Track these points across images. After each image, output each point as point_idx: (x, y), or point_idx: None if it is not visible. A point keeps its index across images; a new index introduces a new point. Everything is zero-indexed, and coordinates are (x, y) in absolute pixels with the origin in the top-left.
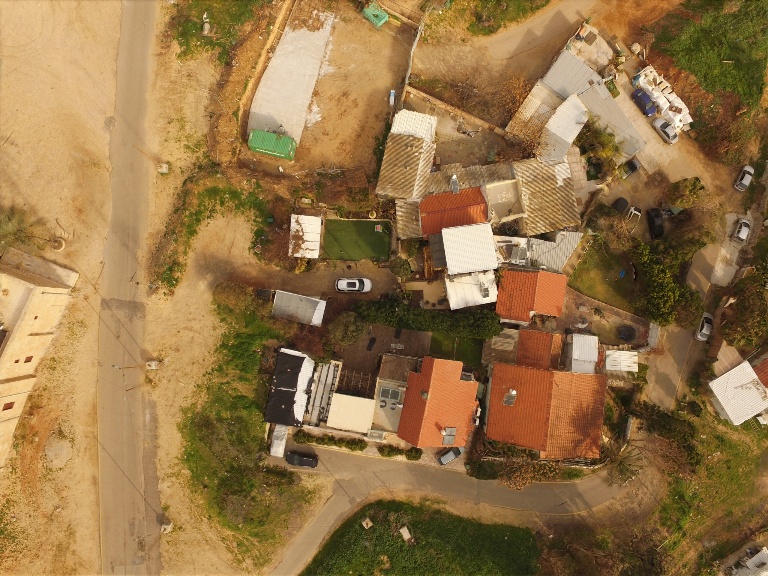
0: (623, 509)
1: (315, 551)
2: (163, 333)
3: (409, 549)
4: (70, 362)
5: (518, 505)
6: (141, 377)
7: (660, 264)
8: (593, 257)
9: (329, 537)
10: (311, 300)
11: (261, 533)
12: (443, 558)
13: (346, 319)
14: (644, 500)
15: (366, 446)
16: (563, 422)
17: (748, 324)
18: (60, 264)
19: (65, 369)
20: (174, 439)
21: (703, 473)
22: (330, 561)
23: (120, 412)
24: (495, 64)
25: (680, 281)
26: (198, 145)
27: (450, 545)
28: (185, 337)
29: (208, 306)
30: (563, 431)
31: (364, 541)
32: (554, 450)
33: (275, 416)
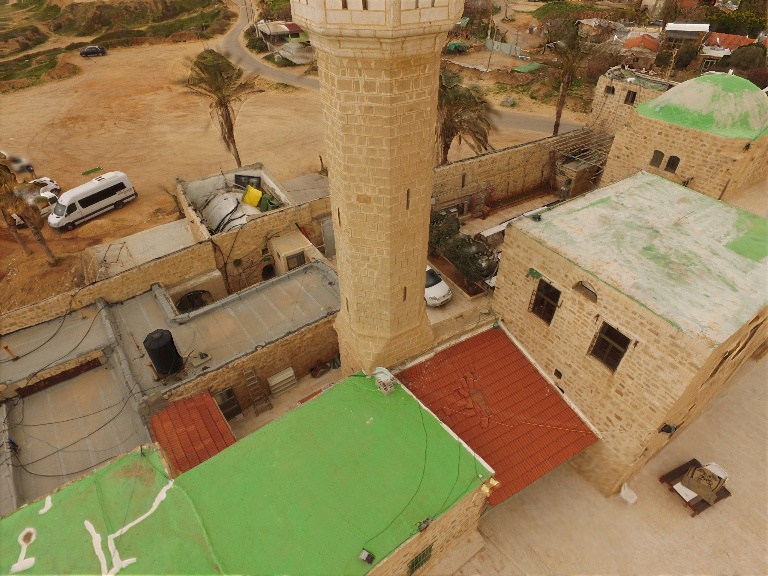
0: None
1: None
2: None
3: None
4: None
5: None
6: None
7: None
8: None
9: None
10: None
11: None
12: None
13: None
14: None
15: None
16: None
17: None
18: None
19: None
20: None
21: None
22: None
23: None
24: (527, 45)
25: None
26: (501, 88)
27: None
28: None
29: None
30: None
31: None
32: None
33: None
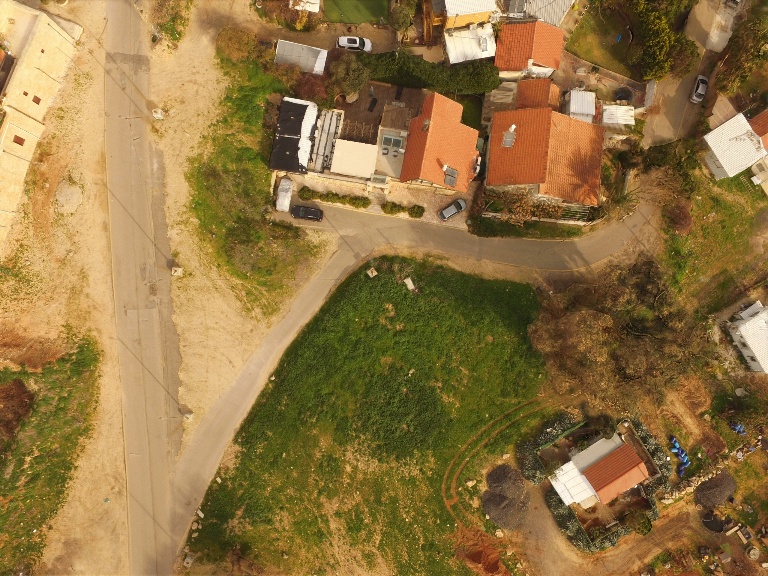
0: (621, 265)
1: (322, 302)
2: (168, 86)
3: (413, 297)
4: (77, 112)
5: (519, 262)
6: (147, 127)
7: (656, 11)
8: (590, 22)
9: (335, 289)
10: (313, 49)
11: (269, 282)
12: (446, 307)
13: (347, 57)
14: (641, 257)
15: (369, 203)
16: (561, 163)
17: (742, 59)
18: (64, 18)
19: (73, 118)
20: (182, 188)
21: (698, 233)
22: (337, 308)
23: (128, 160)
24: None
25: (675, 30)
26: None
27: (453, 295)
28: (189, 90)
29: (211, 60)
30: (562, 172)
31: (369, 288)
32: (553, 189)
33: (280, 162)
